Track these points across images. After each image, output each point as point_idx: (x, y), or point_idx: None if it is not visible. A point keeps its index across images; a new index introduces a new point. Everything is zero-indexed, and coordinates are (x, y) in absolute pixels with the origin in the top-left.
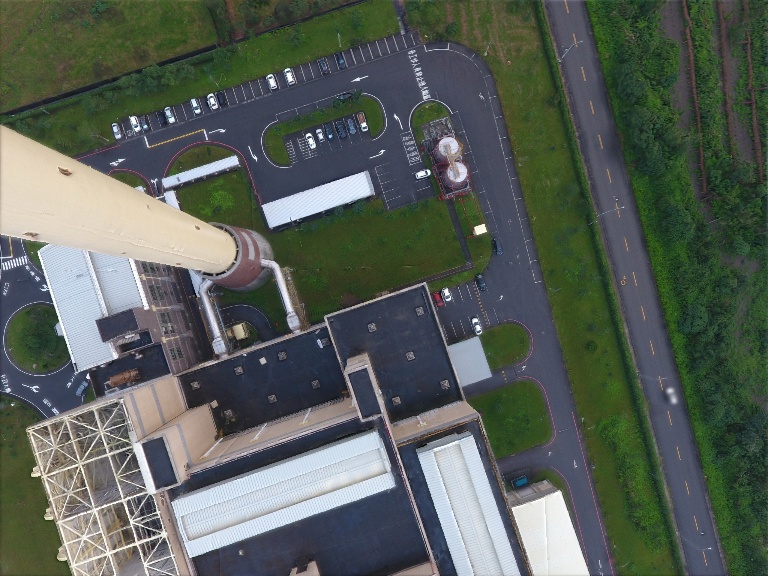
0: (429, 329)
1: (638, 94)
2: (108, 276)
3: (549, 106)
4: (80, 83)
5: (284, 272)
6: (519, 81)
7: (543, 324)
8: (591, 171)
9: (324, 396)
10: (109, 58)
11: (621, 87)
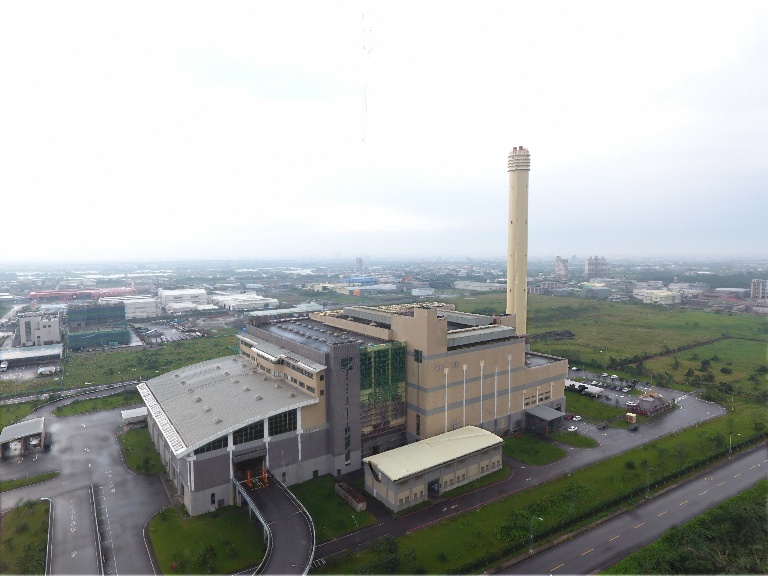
0: None
1: None
2: None
3: None
4: None
5: None
6: None
7: None
8: None
9: None
10: None
11: None
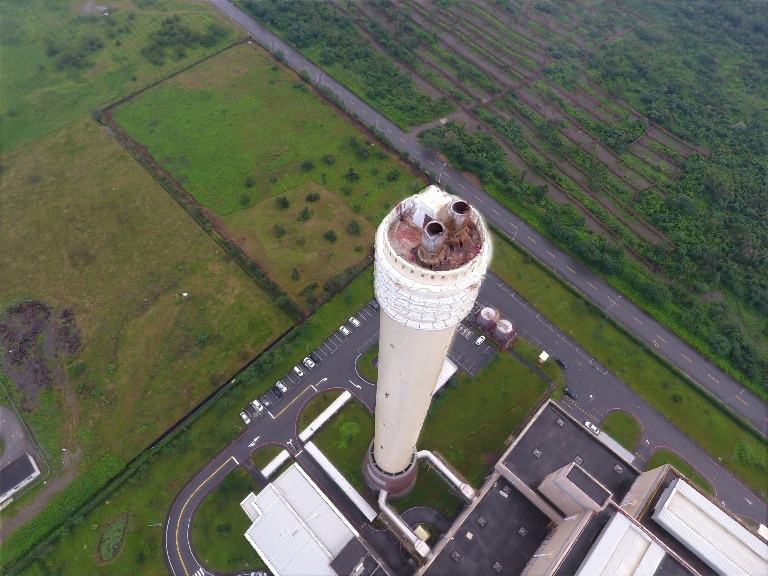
0: (576, 432)
1: (572, 235)
2: (315, 523)
3: (527, 264)
4: (203, 396)
5: (435, 455)
6: (499, 259)
7: (633, 401)
8: (580, 288)
9: (535, 539)
10: (220, 369)
11: (560, 236)
